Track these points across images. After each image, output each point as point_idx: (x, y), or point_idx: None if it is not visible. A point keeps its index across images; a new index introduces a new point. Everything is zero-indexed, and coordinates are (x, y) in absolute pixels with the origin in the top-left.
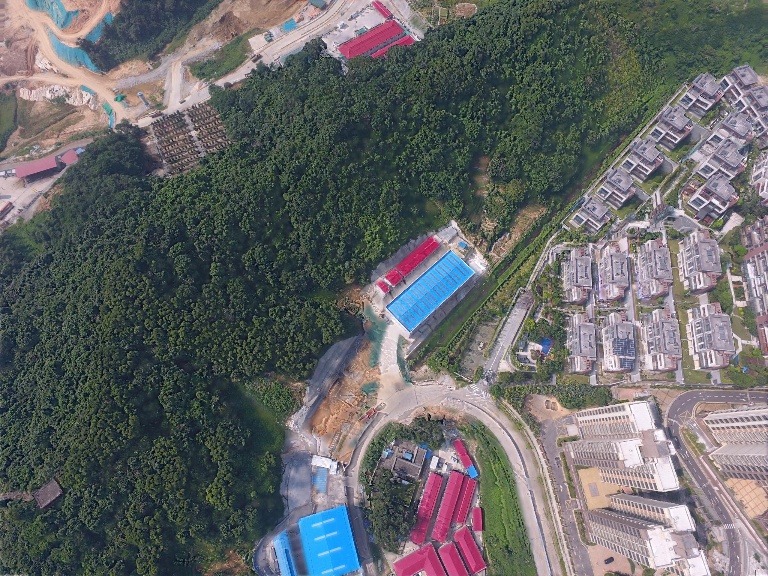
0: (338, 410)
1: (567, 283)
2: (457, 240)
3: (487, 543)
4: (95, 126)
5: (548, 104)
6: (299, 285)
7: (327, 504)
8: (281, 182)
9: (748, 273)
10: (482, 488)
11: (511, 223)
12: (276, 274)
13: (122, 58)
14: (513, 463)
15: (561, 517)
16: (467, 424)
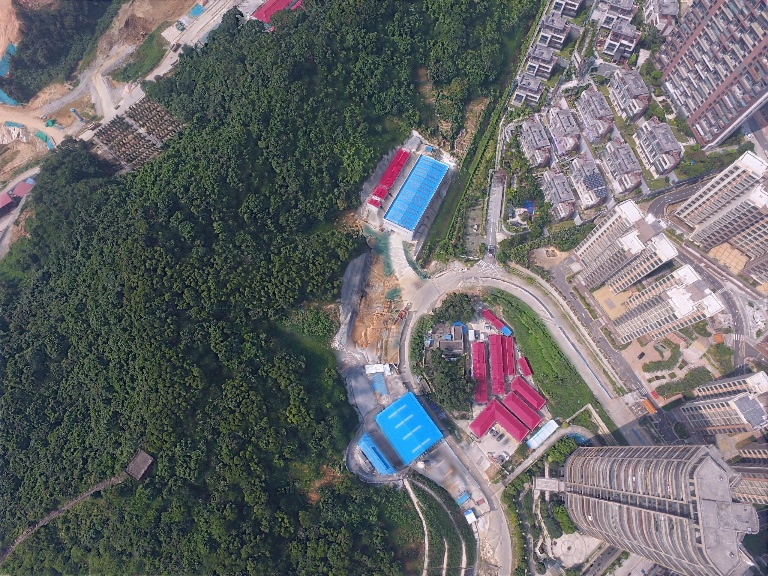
0: (372, 322)
1: (528, 152)
2: (423, 147)
3: (540, 382)
4: (35, 156)
5: (461, 5)
6: (299, 223)
7: (392, 402)
8: (252, 133)
9: (669, 90)
10: (519, 342)
11: (463, 120)
12: (274, 220)
13: (38, 86)
14: (537, 311)
15: (592, 337)
16: (487, 294)
